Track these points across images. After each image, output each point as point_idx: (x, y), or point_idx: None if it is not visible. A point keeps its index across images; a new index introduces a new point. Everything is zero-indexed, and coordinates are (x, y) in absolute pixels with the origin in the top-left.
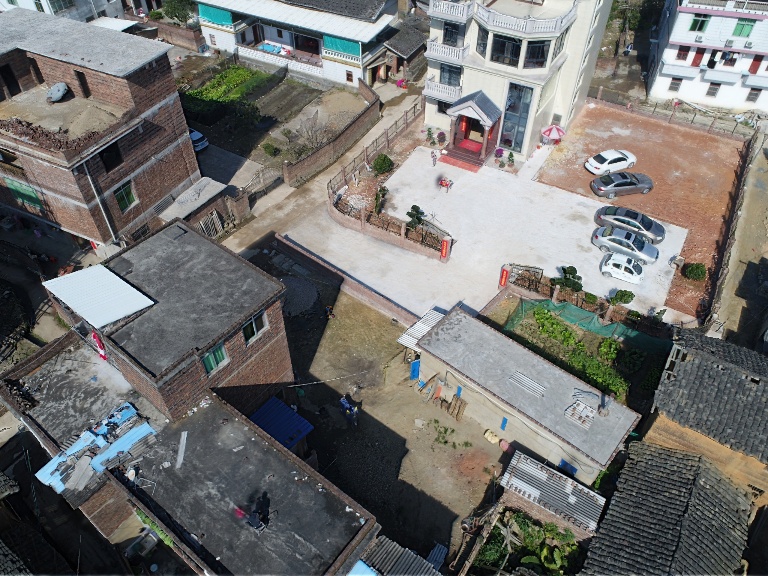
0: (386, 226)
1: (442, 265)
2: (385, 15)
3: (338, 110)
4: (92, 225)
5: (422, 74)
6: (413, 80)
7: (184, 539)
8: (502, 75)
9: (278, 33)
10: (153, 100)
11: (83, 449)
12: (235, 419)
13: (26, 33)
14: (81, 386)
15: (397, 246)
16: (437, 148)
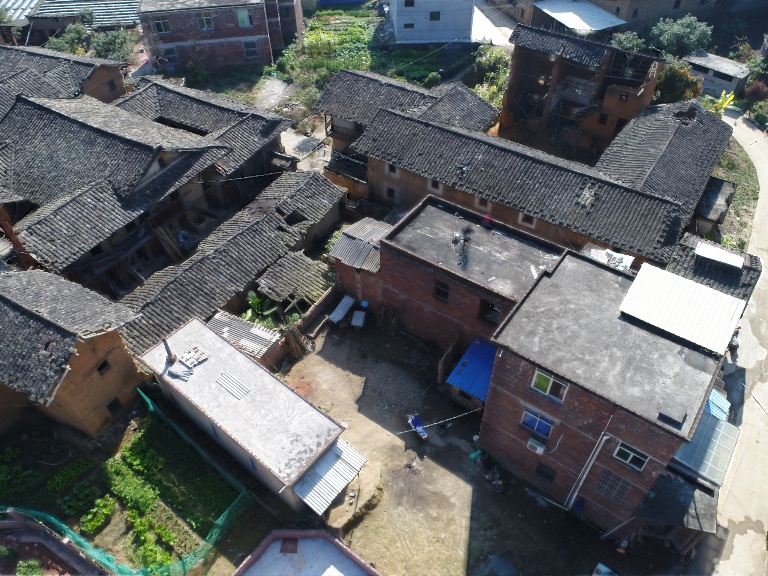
0: None
1: None
2: None
3: None
4: None
5: None
6: None
7: (504, 232)
8: None
9: None
10: None
11: None
12: None
13: None
14: None
15: None
16: None
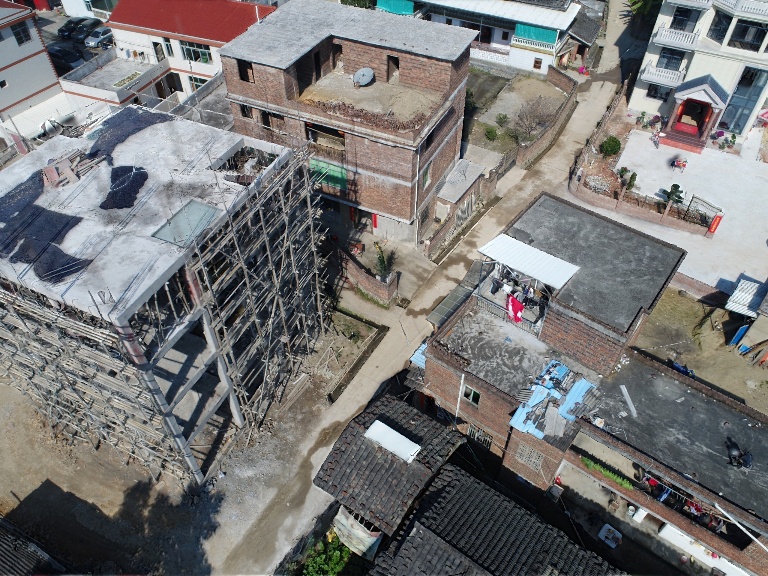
0: (637, 205)
1: (708, 240)
2: (572, 3)
3: (534, 96)
4: (405, 203)
5: (596, 61)
6: (592, 67)
7: None
8: (739, 59)
9: (447, 22)
10: (457, 84)
11: (545, 401)
12: (661, 374)
13: (329, 21)
14: (500, 346)
15: (655, 223)
16: (652, 131)
